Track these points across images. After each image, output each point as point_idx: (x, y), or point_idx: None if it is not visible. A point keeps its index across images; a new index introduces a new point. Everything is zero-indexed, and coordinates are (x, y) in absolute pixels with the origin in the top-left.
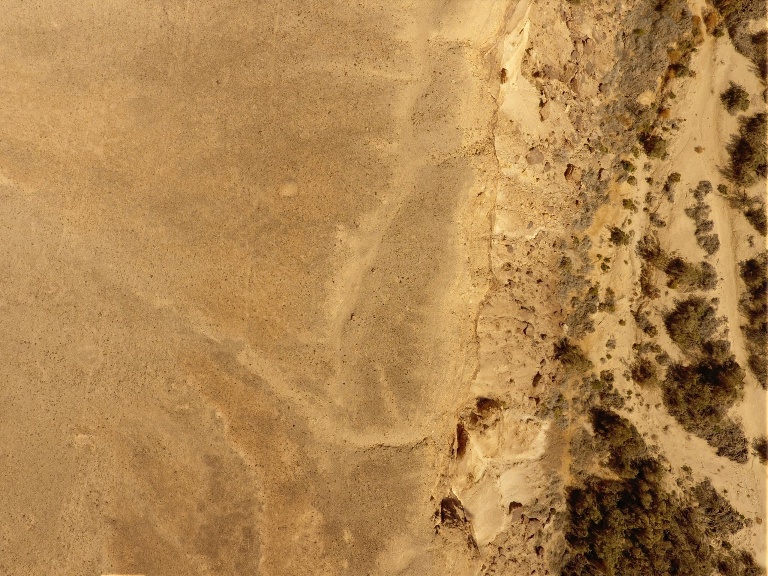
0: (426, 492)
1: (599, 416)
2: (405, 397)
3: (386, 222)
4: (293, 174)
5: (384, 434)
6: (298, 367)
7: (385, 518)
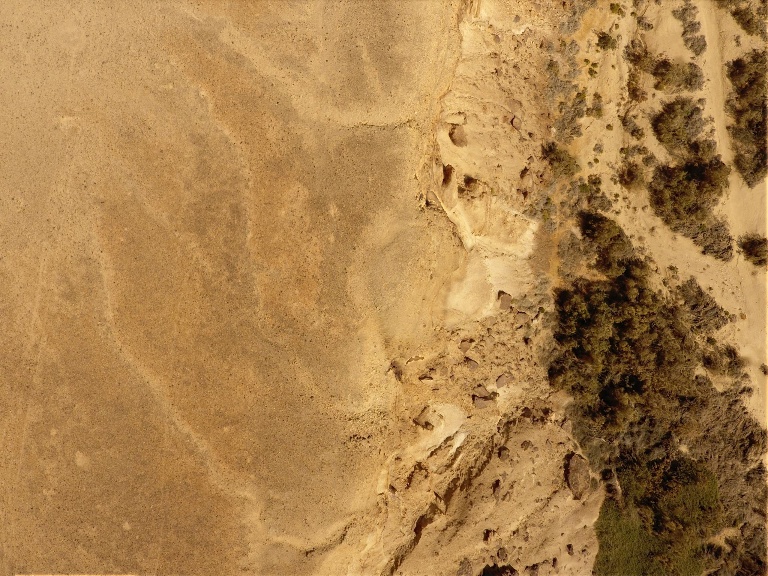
0: (410, 169)
1: (587, 219)
2: (388, 72)
3: None
4: None
5: (367, 111)
6: (280, 43)
7: (370, 192)
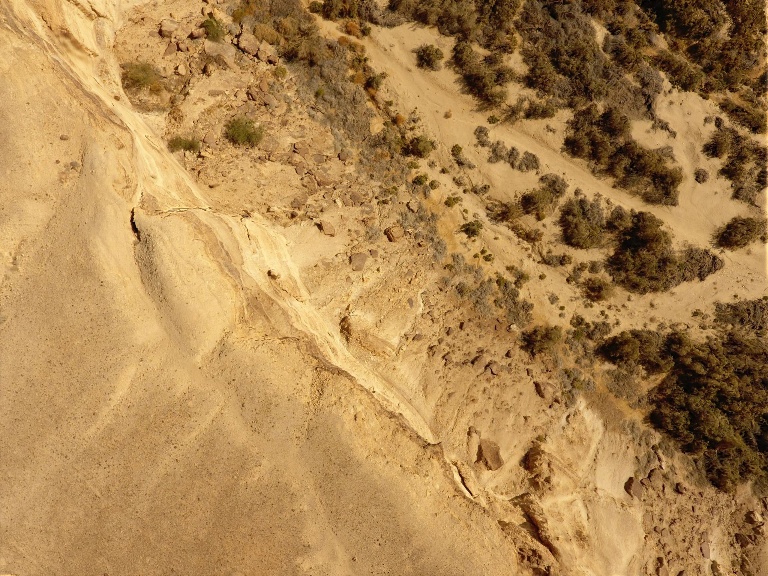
0: None
1: (604, 352)
2: None
3: (322, 519)
4: (227, 569)
5: None
6: None
7: None
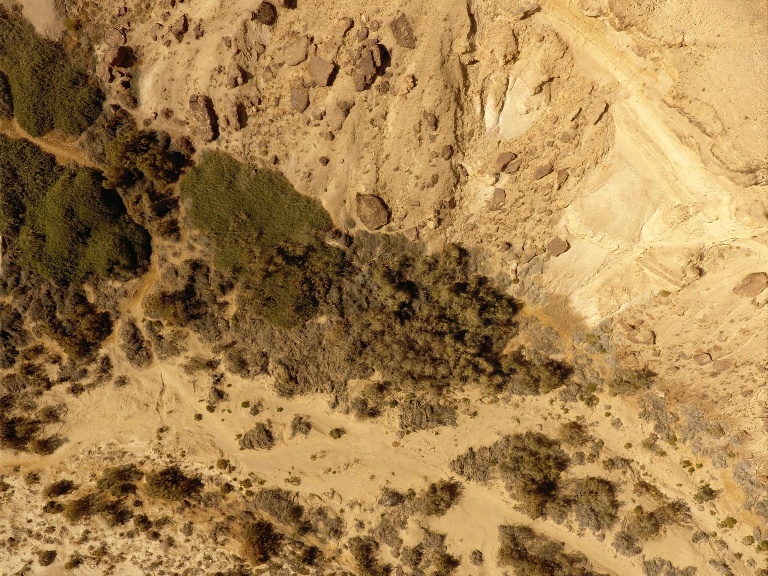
0: None
1: None
2: None
3: None
4: None
5: None
6: None
7: None
